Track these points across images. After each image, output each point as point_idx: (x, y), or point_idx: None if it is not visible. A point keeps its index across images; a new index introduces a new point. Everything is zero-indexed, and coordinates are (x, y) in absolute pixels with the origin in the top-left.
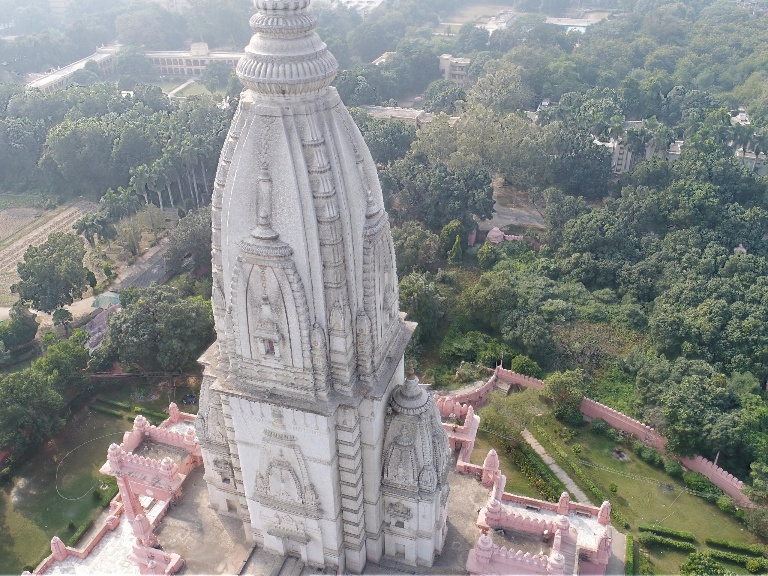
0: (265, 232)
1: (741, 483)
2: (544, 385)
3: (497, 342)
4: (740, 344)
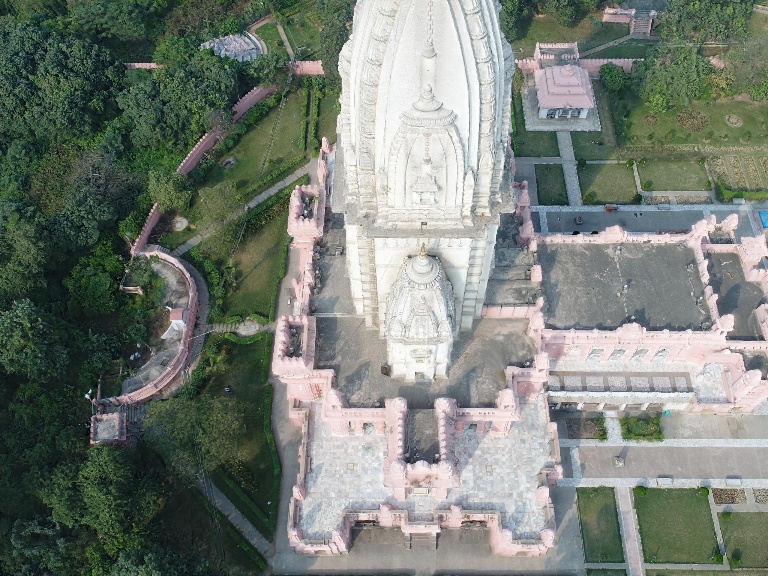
0: (507, 45)
1: (256, 88)
2: (155, 212)
3: (88, 257)
4: (94, 68)
